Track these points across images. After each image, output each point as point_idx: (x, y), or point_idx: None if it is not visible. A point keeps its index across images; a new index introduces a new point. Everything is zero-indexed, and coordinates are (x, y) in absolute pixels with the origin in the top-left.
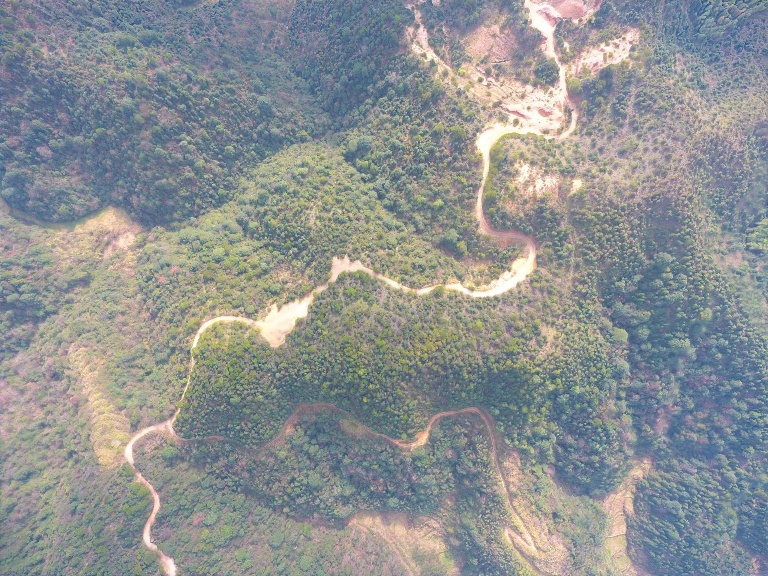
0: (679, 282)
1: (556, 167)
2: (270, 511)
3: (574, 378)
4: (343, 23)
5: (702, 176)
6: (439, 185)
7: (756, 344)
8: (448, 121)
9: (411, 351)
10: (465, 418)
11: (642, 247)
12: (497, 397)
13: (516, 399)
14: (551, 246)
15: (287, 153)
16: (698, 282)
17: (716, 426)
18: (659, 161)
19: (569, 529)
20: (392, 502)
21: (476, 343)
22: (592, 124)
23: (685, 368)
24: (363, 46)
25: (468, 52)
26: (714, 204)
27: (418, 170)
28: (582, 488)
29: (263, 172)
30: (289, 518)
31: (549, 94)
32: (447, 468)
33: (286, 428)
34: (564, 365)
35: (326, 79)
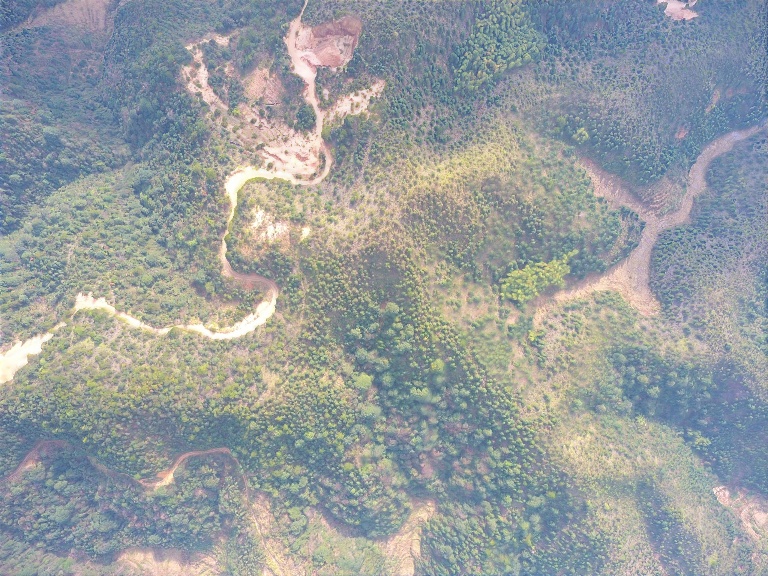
0: (406, 333)
1: (288, 214)
2: (26, 545)
3: (304, 424)
4: (136, 58)
5: (425, 229)
6: (197, 224)
7: (499, 395)
8: (208, 162)
9: (124, 394)
10: (214, 458)
11: (373, 296)
12: (234, 440)
13: (245, 443)
14: (287, 291)
15: (83, 182)
16: (422, 334)
17: (478, 473)
18: (375, 214)
19: (330, 572)
20: (152, 540)
21: (199, 387)
22: (337, 172)
23: (438, 415)
24: (145, 82)
25: (247, 93)
26: (448, 256)
27: (183, 208)
28: (361, 529)
29: (51, 201)
30: (49, 552)
31: (307, 139)
32: (207, 507)
33: (26, 463)
34: (287, 412)
35: (121, 111)
